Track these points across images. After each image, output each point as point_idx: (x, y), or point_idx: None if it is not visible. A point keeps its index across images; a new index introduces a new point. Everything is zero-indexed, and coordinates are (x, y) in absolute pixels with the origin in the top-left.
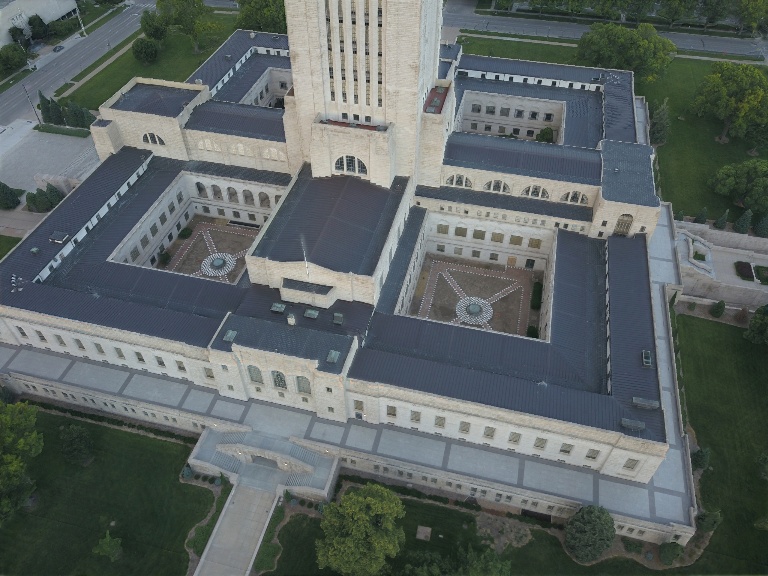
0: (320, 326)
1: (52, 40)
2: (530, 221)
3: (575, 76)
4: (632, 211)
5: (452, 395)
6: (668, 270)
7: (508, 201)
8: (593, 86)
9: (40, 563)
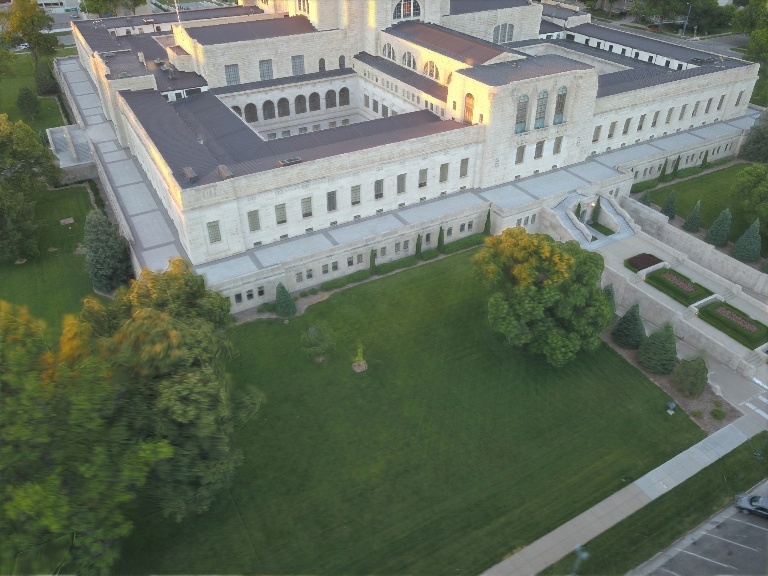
0: (161, 76)
1: None
2: (411, 96)
3: (679, 55)
4: (472, 89)
5: (142, 119)
6: (519, 201)
7: (410, 76)
8: (691, 67)
9: None
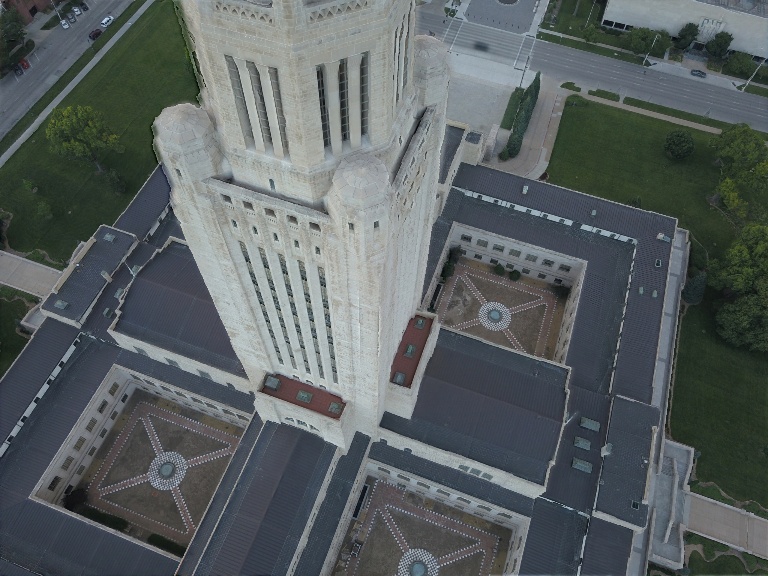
0: (109, 301)
1: (717, 64)
2: None
3: None
4: None
5: (0, 392)
6: None
7: None
8: None
9: (59, 183)
